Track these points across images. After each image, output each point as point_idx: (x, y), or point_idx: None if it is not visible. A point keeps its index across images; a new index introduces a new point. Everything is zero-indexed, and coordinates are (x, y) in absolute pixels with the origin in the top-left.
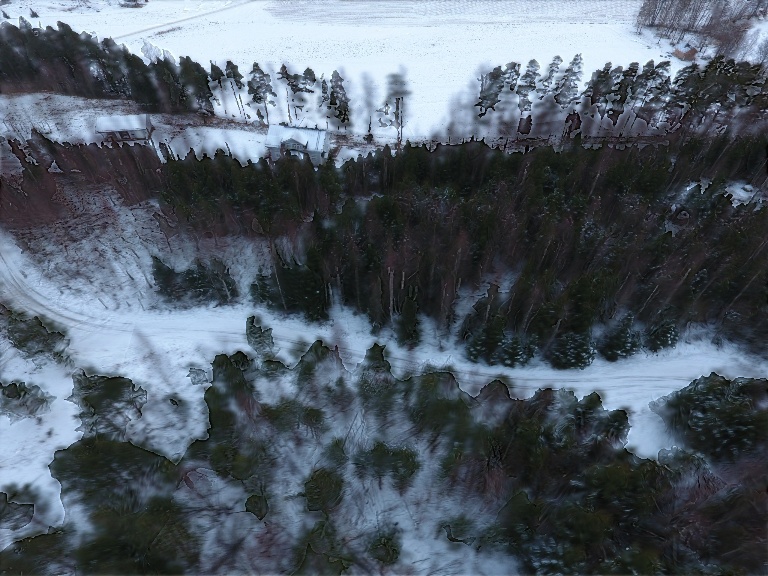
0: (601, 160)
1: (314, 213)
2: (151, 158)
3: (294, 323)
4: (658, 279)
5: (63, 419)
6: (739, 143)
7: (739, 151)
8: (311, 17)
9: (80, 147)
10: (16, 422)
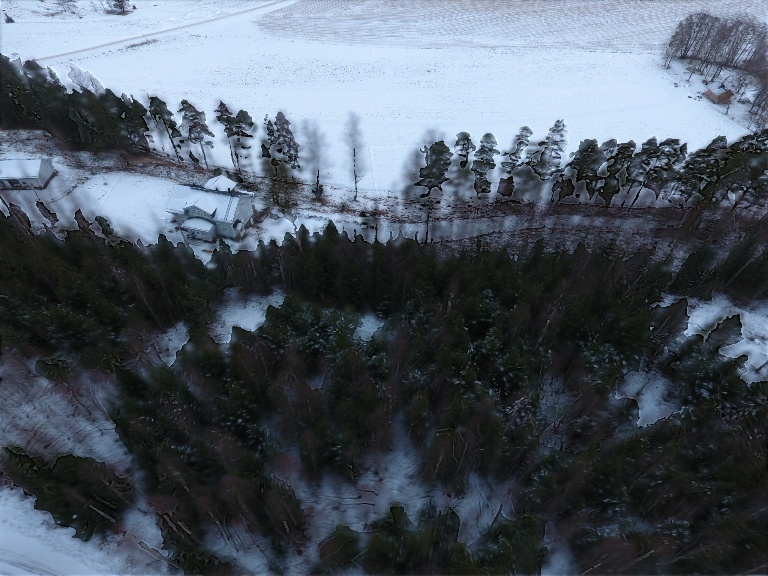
0: (569, 277)
1: (115, 370)
2: (5, 229)
3: (65, 536)
4: (606, 538)
5: None
6: (767, 258)
7: (766, 270)
8: (301, 33)
9: None
10: None
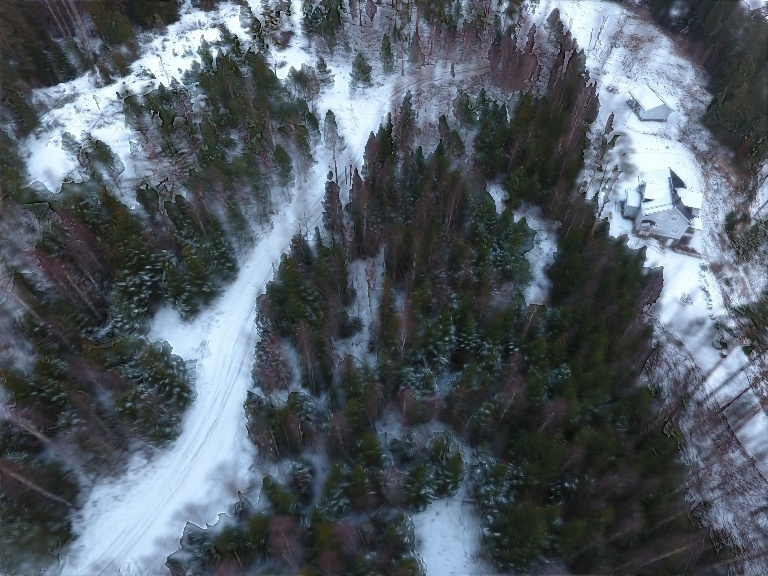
0: (634, 496)
1: None
2: (573, 104)
3: None
4: None
5: None
6: None
7: None
8: None
9: (579, 75)
10: None
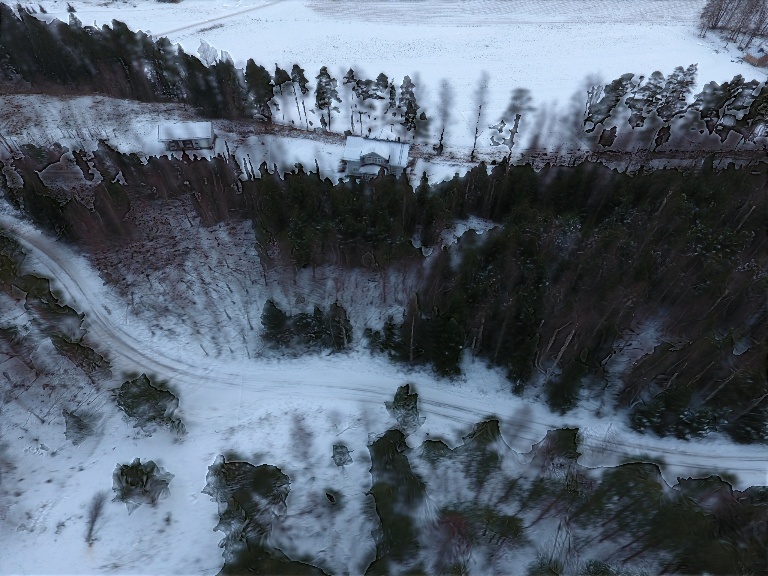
0: None
1: (443, 250)
2: (228, 173)
3: (422, 377)
4: None
5: (181, 500)
6: None
7: None
8: (355, 15)
9: None
10: (134, 510)
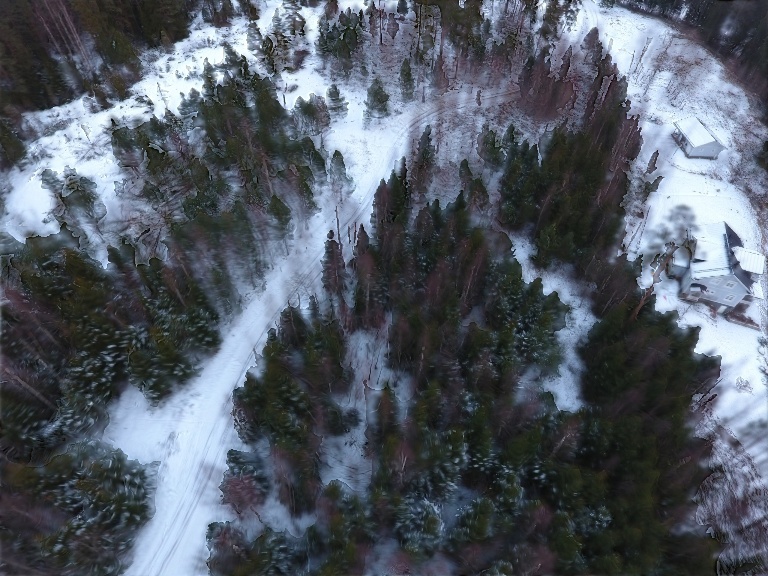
0: None
1: None
2: (612, 141)
3: None
4: (272, 536)
5: (333, 128)
6: None
7: None
8: None
9: (619, 106)
10: None
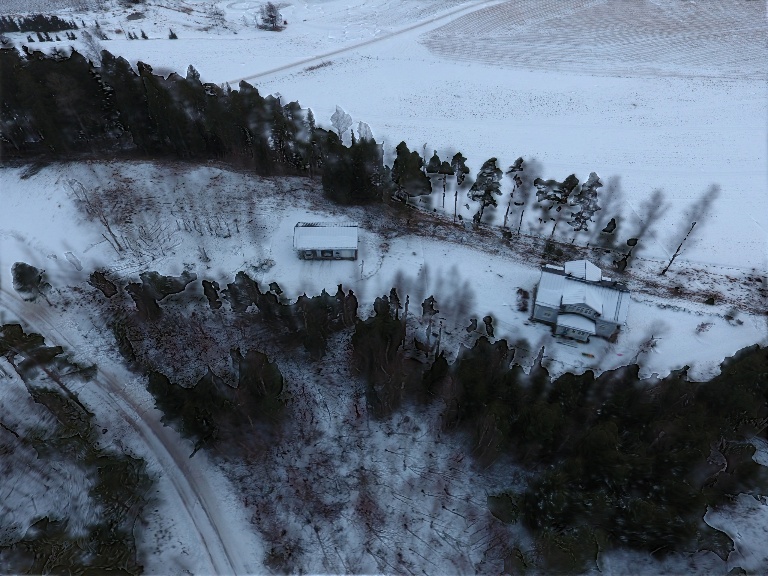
0: None
1: None
2: (403, 334)
3: None
4: None
5: None
6: None
7: None
8: (474, 56)
9: (298, 300)
10: None
